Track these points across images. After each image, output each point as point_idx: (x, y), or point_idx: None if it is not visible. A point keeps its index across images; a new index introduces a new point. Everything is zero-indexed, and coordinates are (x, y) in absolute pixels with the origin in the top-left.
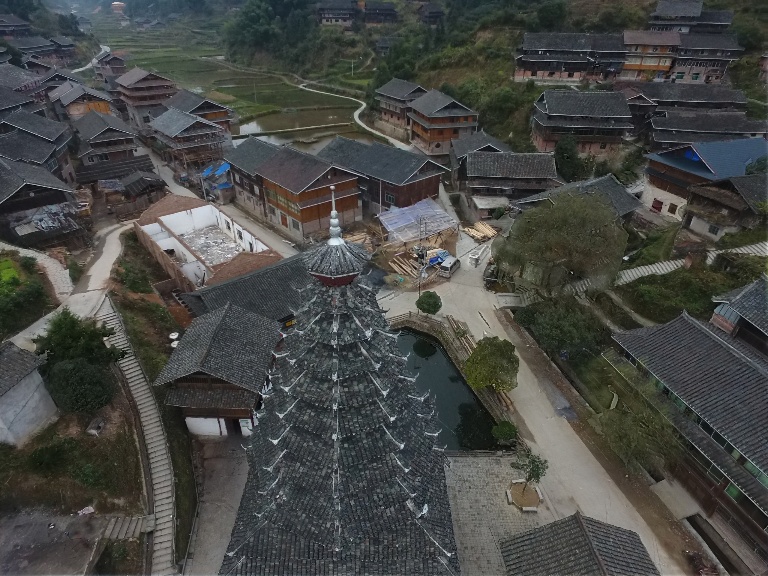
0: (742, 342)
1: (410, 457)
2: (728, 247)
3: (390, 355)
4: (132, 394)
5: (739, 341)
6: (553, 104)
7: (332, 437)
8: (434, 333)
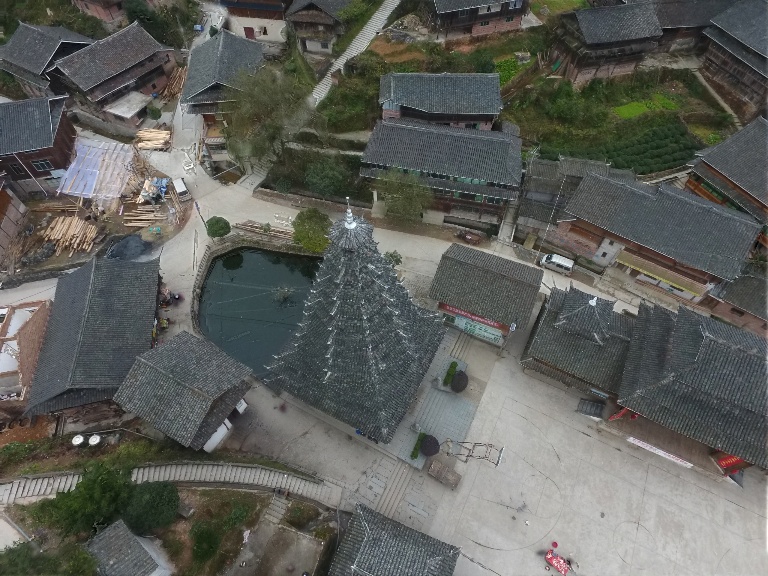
0: (405, 118)
1: None
2: (340, 54)
3: None
4: None
5: (404, 119)
6: None
7: None
8: (238, 245)
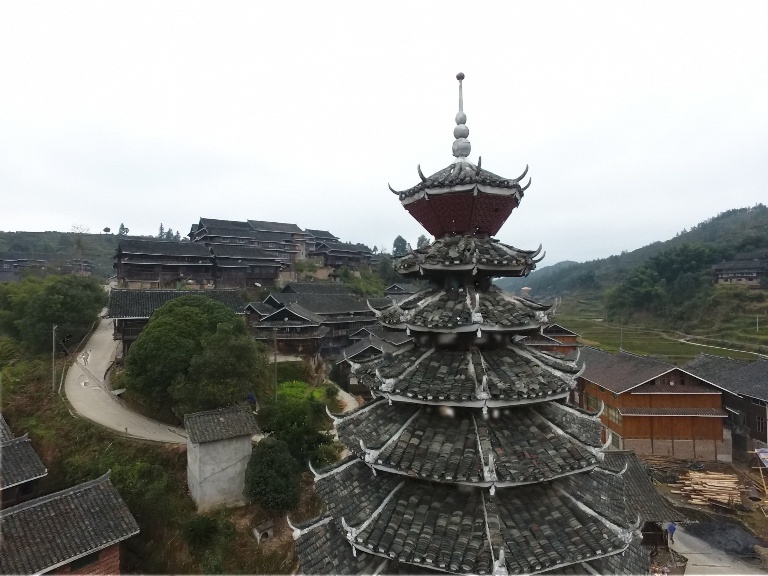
0: None
1: None
2: None
3: (557, 431)
4: None
5: None
6: None
7: (346, 534)
8: None
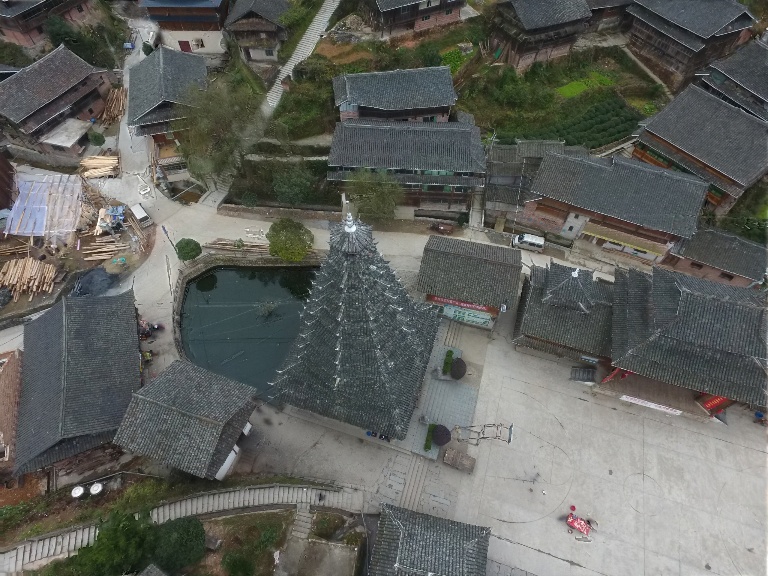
0: (364, 118)
1: None
2: (286, 60)
3: None
4: None
5: None
6: None
7: None
8: (211, 265)
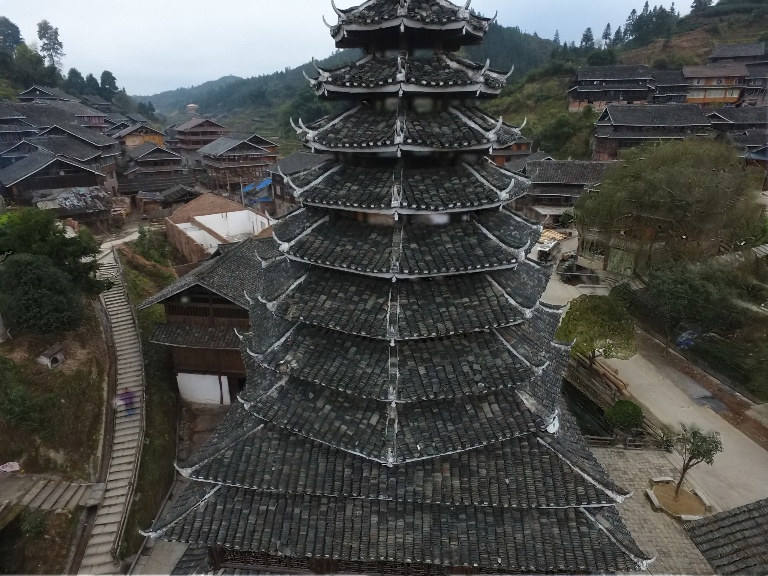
0: None
1: None
2: None
3: (491, 121)
4: (114, 339)
5: None
6: (618, 116)
7: (391, 204)
8: None
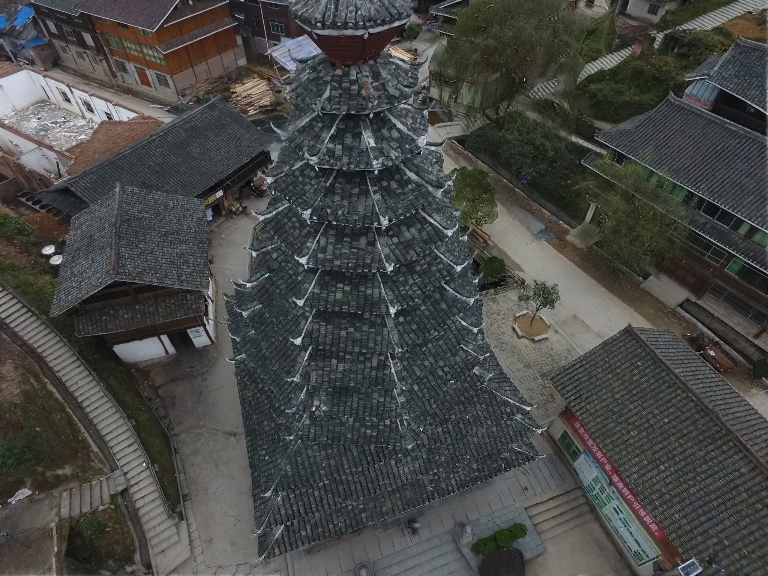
0: None
1: (471, 313)
2: (669, 27)
3: None
4: (20, 336)
5: None
6: None
7: (390, 312)
8: None
